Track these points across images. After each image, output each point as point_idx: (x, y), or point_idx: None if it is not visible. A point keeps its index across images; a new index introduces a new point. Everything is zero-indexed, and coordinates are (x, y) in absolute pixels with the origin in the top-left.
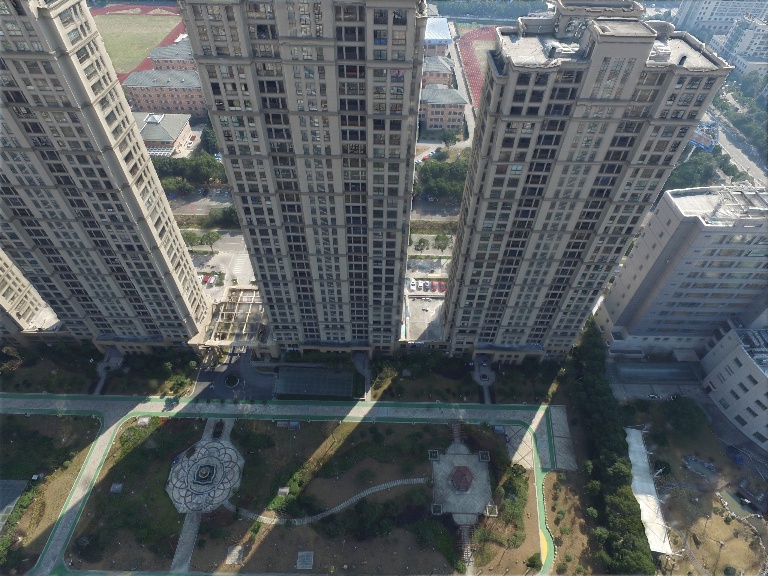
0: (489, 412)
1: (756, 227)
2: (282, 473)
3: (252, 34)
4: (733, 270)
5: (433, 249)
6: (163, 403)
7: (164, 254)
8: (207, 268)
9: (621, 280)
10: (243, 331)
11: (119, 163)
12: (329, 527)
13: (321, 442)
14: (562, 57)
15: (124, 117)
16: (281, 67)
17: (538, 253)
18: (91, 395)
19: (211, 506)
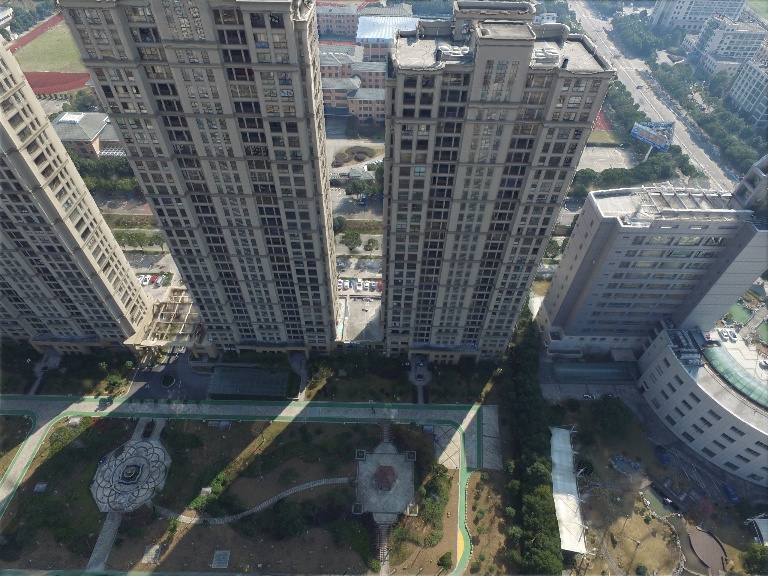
0: (421, 412)
1: (673, 228)
2: (207, 473)
3: (136, 37)
4: (657, 271)
5: None
6: (97, 403)
7: (88, 255)
8: (156, 268)
9: (556, 280)
10: (180, 331)
11: (27, 165)
12: (246, 526)
13: (250, 442)
14: (451, 60)
15: (33, 119)
16: (170, 70)
17: (457, 254)
18: (26, 395)
19: (133, 505)
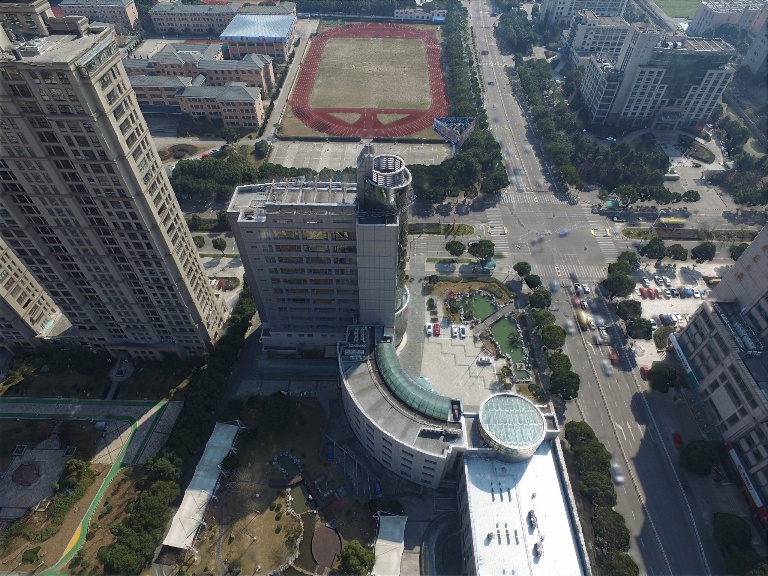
0: (104, 408)
1: (289, 222)
2: None
3: None
4: (308, 266)
5: None
6: None
7: None
8: None
9: None
10: None
11: None
12: None
13: None
14: None
15: None
16: None
17: (79, 249)
18: None
19: None
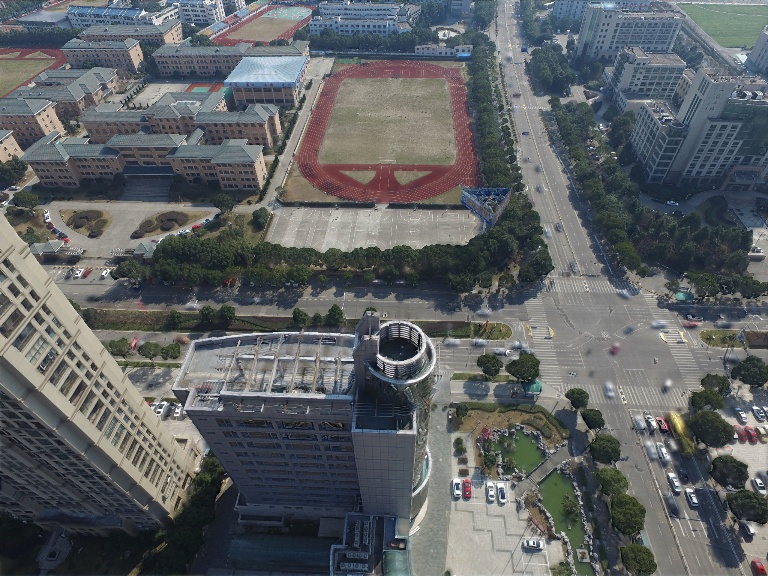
0: None
1: (257, 412)
2: None
3: None
4: (290, 451)
5: (113, 355)
6: None
7: None
8: None
9: None
10: None
11: None
12: None
13: None
14: None
15: None
16: None
17: None
18: None
19: None
